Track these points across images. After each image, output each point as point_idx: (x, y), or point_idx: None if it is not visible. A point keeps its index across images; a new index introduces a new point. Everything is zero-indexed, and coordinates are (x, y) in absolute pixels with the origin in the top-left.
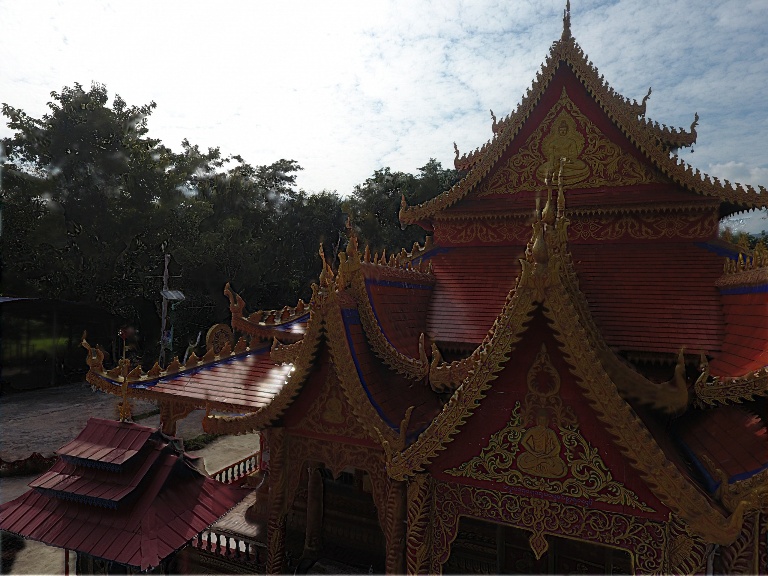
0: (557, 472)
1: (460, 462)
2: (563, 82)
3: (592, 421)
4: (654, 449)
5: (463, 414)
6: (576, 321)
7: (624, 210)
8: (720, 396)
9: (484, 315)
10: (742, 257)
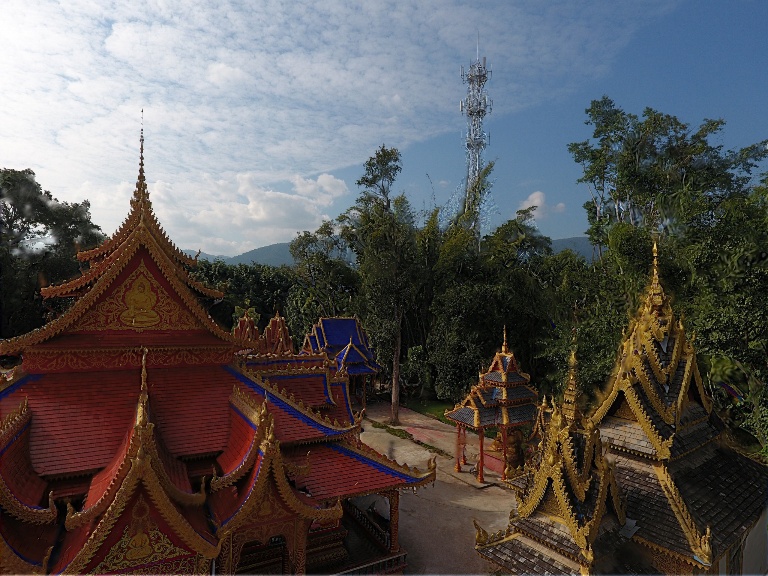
0: (147, 553)
1: (91, 569)
2: (142, 257)
3: (165, 524)
4: (191, 530)
5: (97, 545)
6: (158, 484)
7: (182, 348)
8: (220, 486)
9: (83, 443)
10: (239, 390)
